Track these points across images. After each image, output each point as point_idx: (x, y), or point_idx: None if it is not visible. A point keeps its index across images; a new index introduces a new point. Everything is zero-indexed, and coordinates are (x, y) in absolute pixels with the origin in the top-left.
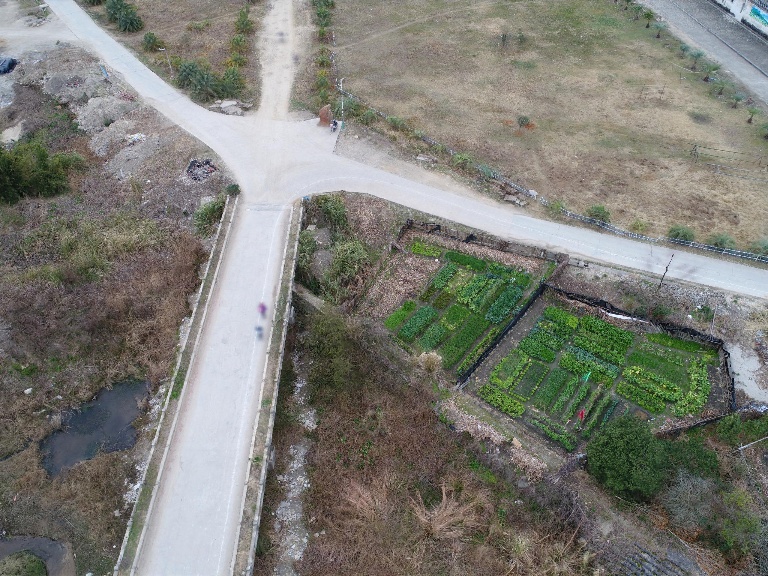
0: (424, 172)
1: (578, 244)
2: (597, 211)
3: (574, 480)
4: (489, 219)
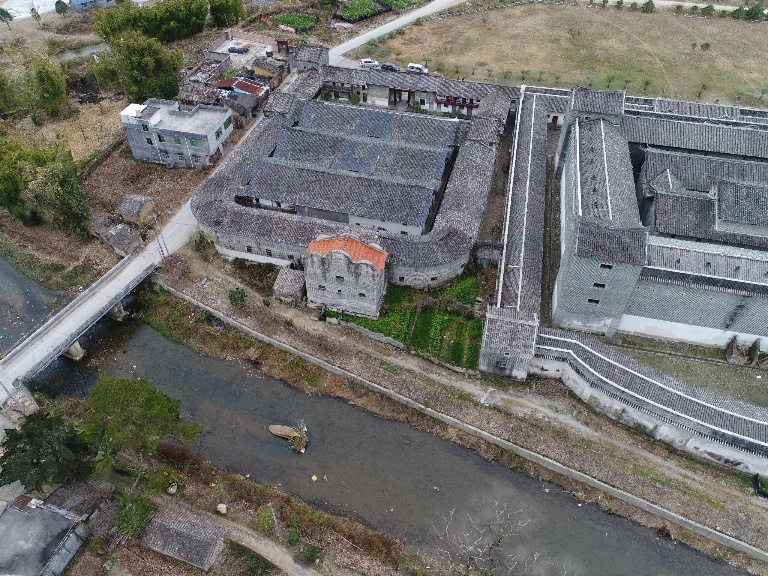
0: (459, 2)
1: None
2: (418, 18)
3: None
4: None
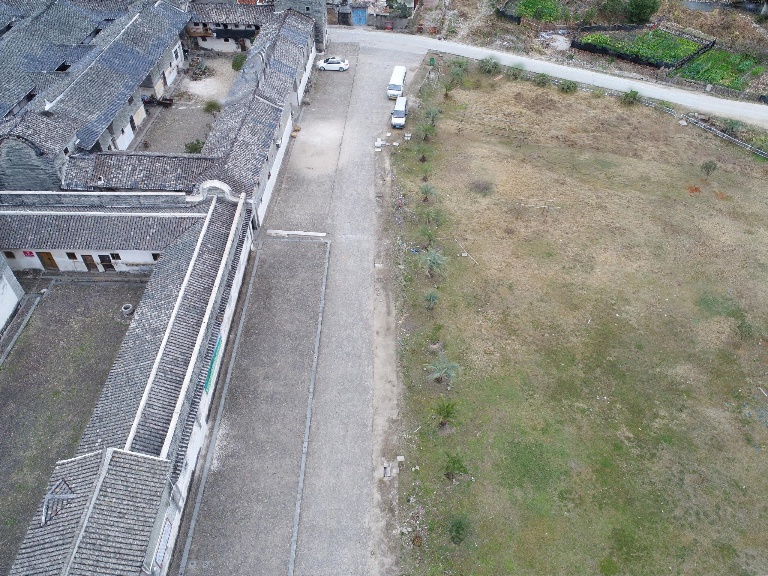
0: None
1: (647, 88)
2: None
3: (656, 20)
4: (718, 104)
